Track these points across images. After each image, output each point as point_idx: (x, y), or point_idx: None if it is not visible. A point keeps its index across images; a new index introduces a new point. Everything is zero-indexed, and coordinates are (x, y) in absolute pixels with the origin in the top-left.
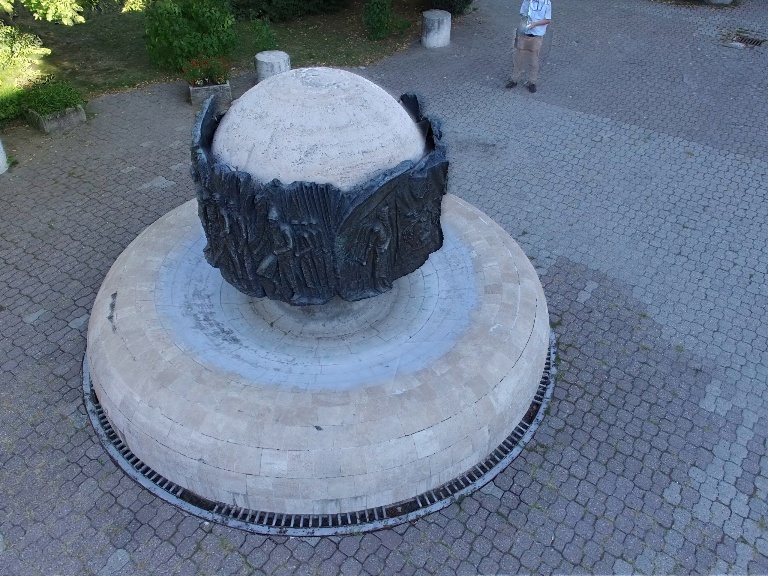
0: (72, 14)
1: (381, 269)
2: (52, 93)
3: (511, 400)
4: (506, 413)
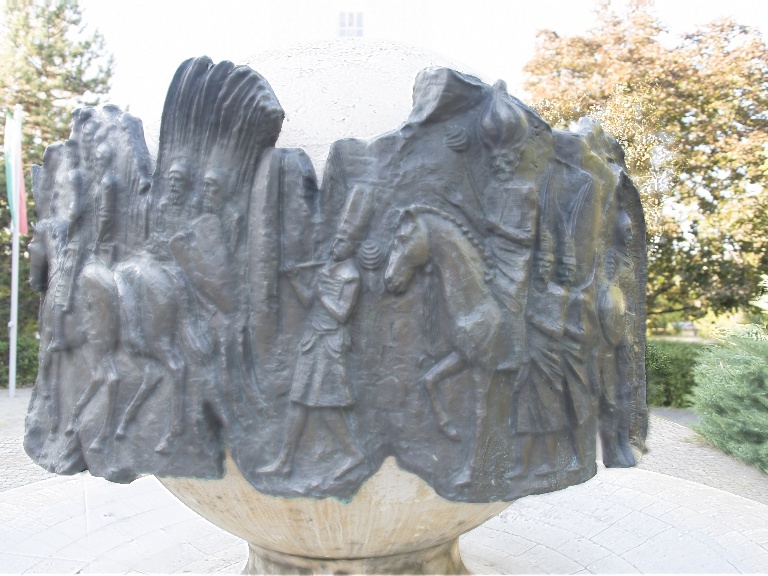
0: None
1: None
2: None
3: None
4: None
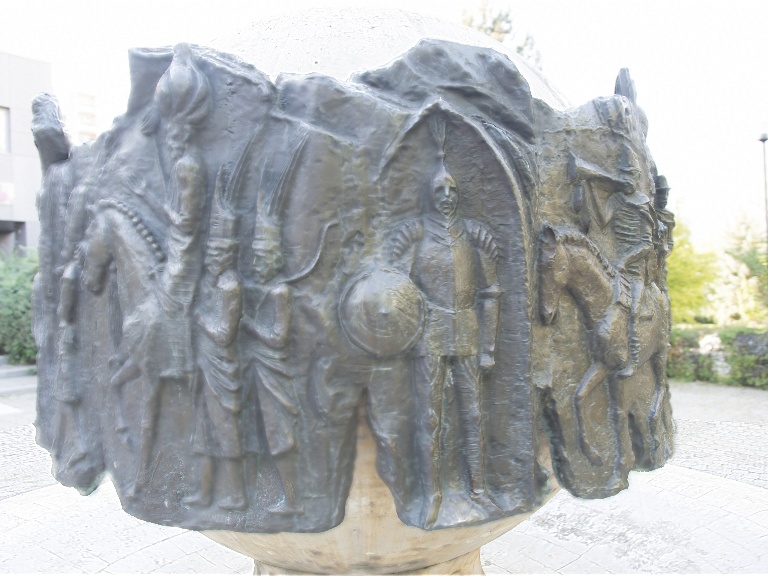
0: None
1: None
2: None
3: None
4: None
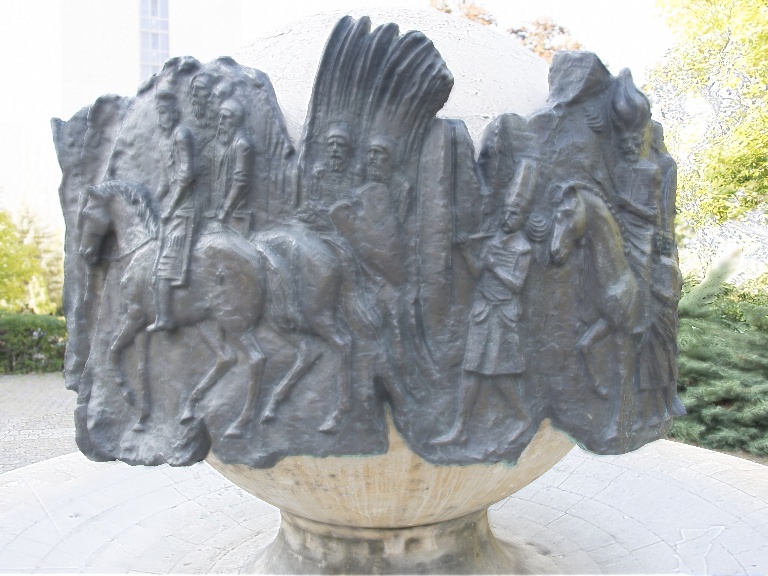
0: None
1: None
2: None
3: None
4: None
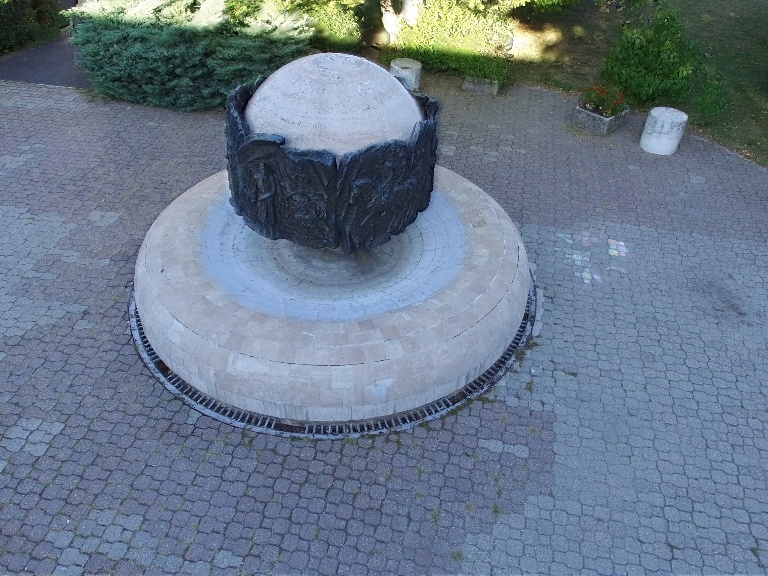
0: (475, 1)
1: (262, 214)
2: (487, 64)
3: (247, 377)
4: (237, 380)
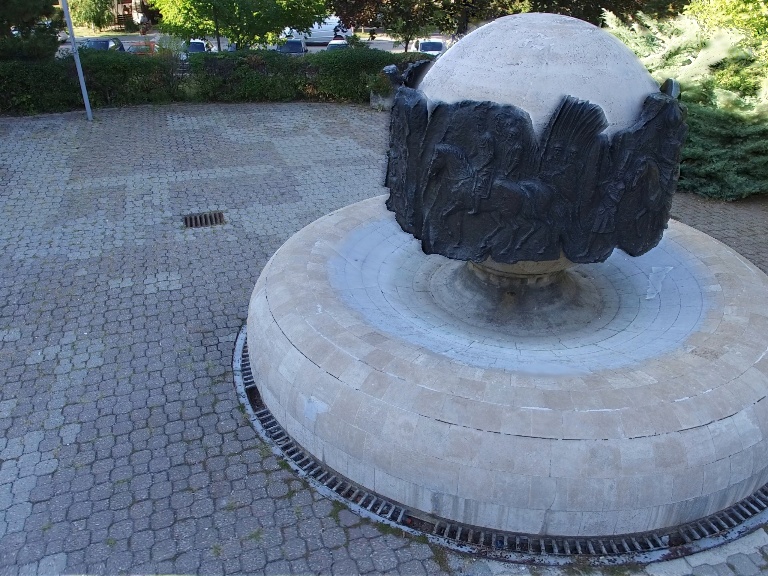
0: None
1: None
2: None
3: None
4: None
